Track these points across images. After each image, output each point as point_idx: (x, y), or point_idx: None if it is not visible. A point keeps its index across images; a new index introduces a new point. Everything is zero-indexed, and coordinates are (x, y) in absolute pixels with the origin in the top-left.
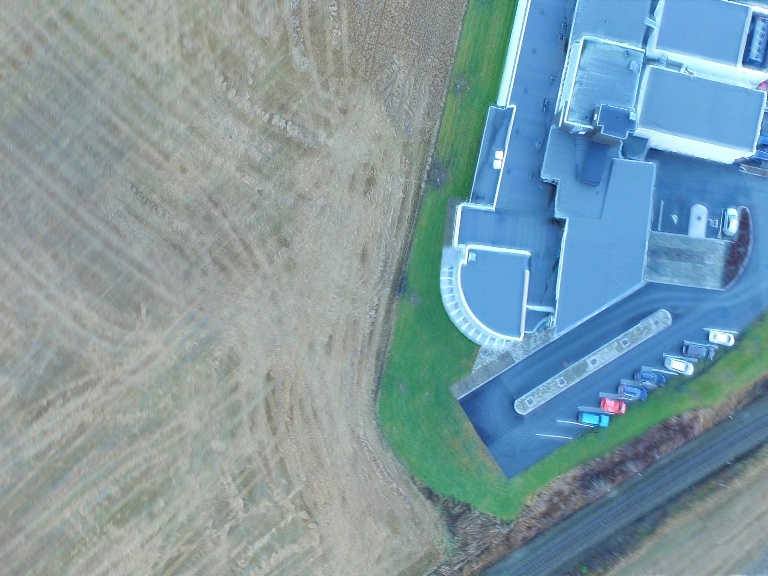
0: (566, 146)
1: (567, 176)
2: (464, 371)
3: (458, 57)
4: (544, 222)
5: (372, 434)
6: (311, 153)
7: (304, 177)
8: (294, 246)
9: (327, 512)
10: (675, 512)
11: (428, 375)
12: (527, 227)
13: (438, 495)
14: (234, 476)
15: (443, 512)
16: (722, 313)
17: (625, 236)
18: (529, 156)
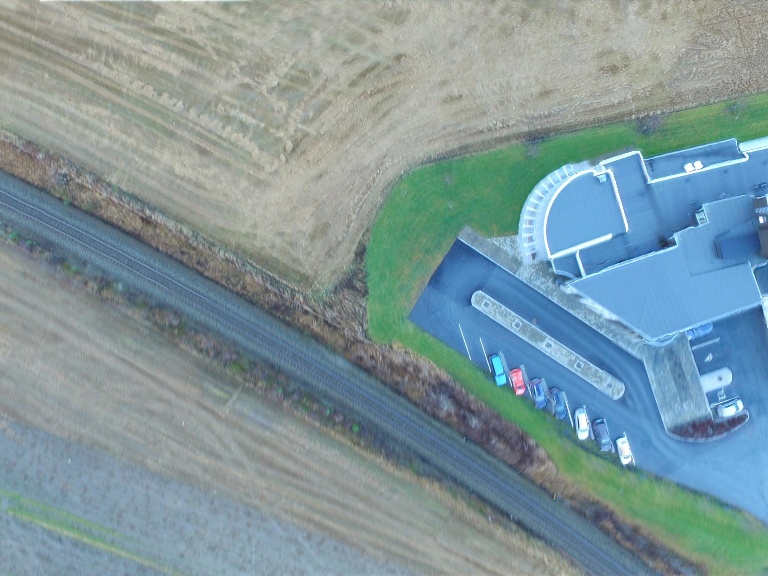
0: (740, 214)
1: (715, 227)
2: (486, 231)
3: (760, 95)
4: (658, 233)
5: (391, 175)
6: (615, 4)
7: (591, 7)
8: (526, 26)
9: (301, 166)
10: (446, 487)
11: (468, 200)
12: (646, 221)
13: (364, 260)
14: (296, 66)
15: (350, 272)
16: (646, 441)
17: (687, 304)
18: (710, 192)
